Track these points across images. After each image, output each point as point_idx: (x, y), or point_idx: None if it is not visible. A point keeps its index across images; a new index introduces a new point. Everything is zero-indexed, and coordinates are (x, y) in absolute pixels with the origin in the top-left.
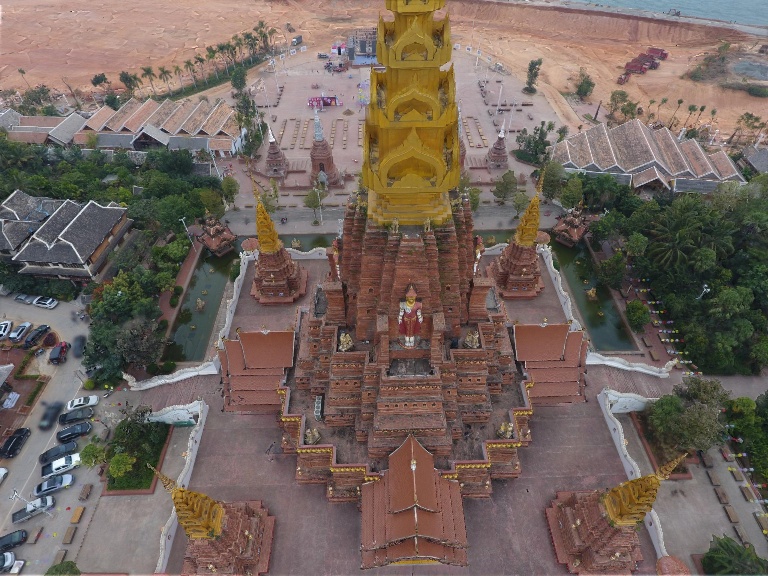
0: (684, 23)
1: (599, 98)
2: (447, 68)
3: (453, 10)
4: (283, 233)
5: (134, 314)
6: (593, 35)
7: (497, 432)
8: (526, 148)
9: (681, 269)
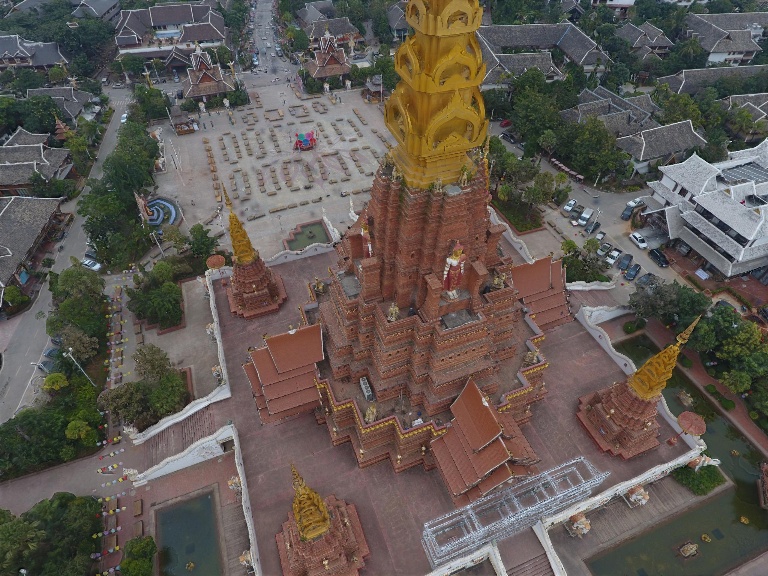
0: None
1: None
2: None
3: None
4: (735, 572)
5: (694, 316)
6: None
7: (326, 290)
8: None
9: None
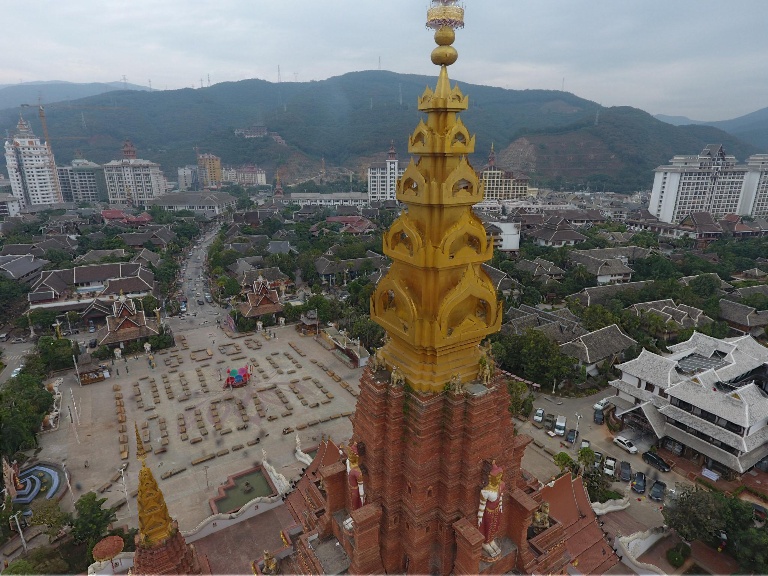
0: None
1: None
2: None
3: None
4: None
5: (749, 529)
6: None
7: (280, 570)
8: None
9: None
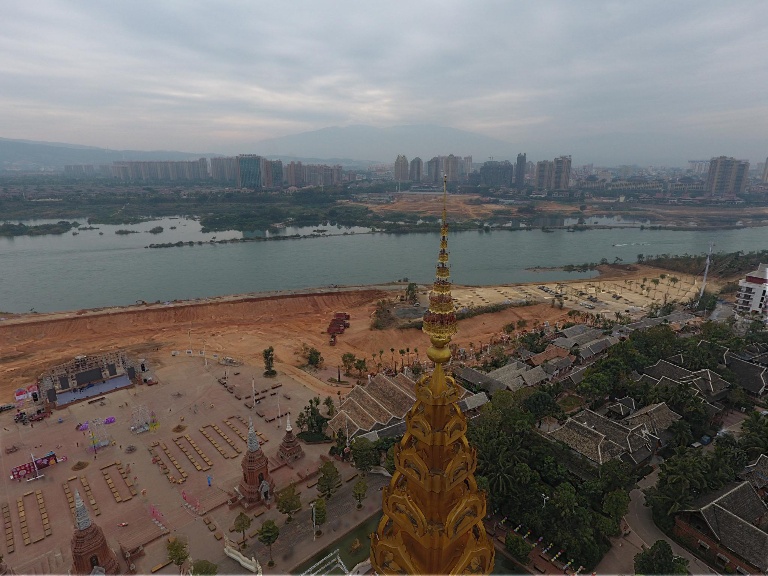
0: (344, 292)
1: (327, 361)
2: (176, 376)
3: (149, 320)
4: None
5: None
6: (287, 313)
7: None
8: (310, 430)
9: (517, 489)
